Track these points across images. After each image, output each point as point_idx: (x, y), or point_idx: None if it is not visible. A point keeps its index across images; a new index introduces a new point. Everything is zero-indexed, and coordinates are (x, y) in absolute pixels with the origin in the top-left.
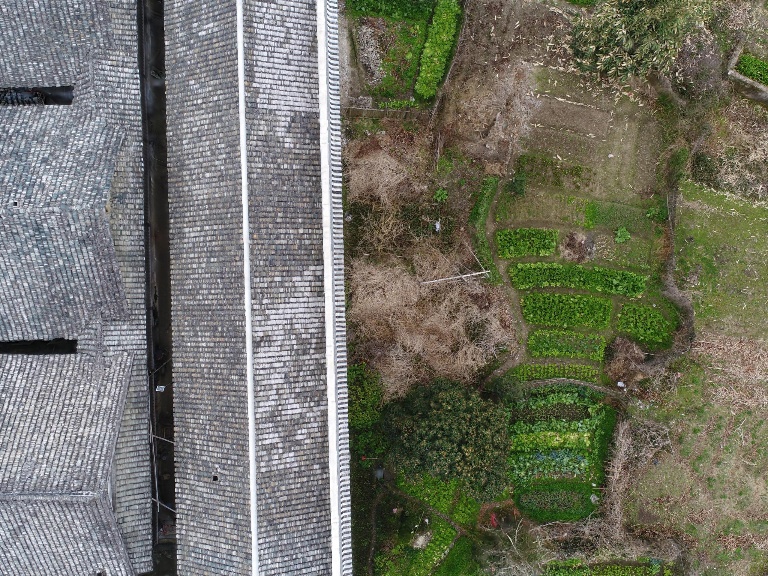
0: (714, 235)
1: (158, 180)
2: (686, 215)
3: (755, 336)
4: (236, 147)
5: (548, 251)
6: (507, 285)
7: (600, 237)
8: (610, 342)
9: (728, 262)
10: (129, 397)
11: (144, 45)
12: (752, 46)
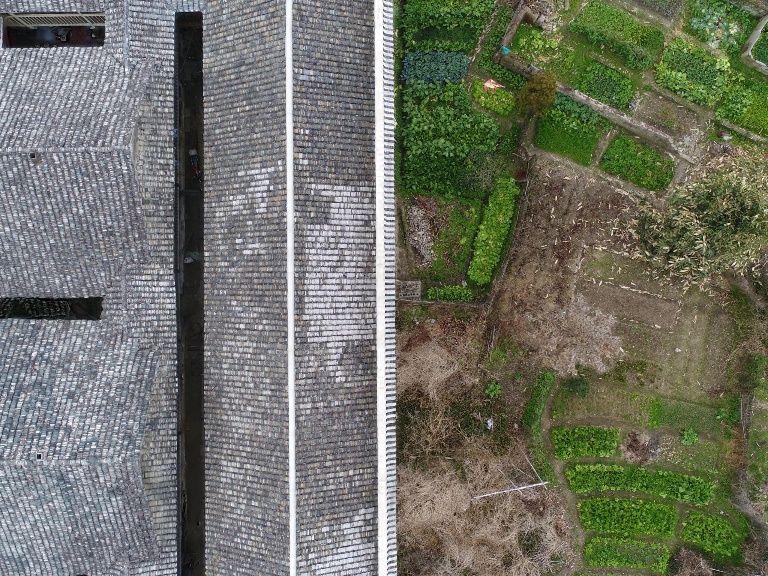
0: None
1: (188, 368)
2: (758, 417)
3: None
4: (283, 387)
5: (609, 453)
6: (563, 487)
7: (665, 438)
8: (674, 552)
9: None
10: None
11: (178, 236)
12: None
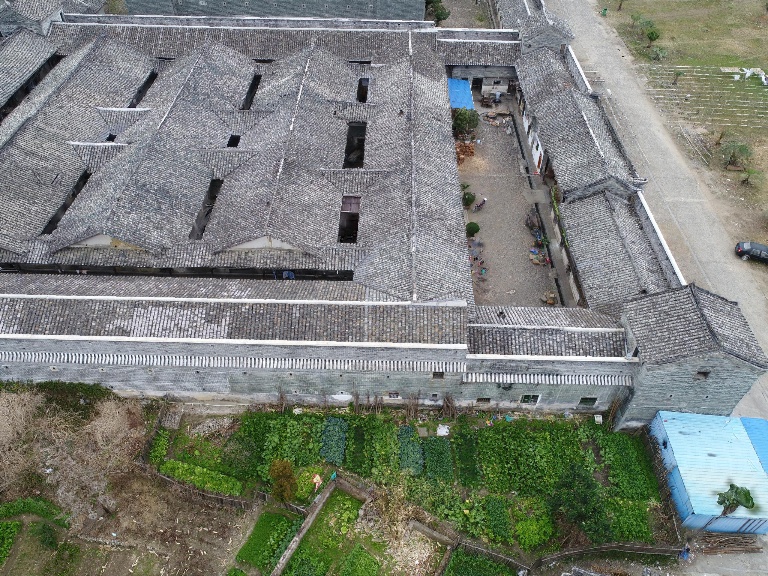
0: None
1: None
2: None
3: None
4: None
5: None
6: None
7: None
8: None
9: None
10: (1, 252)
11: None
12: None
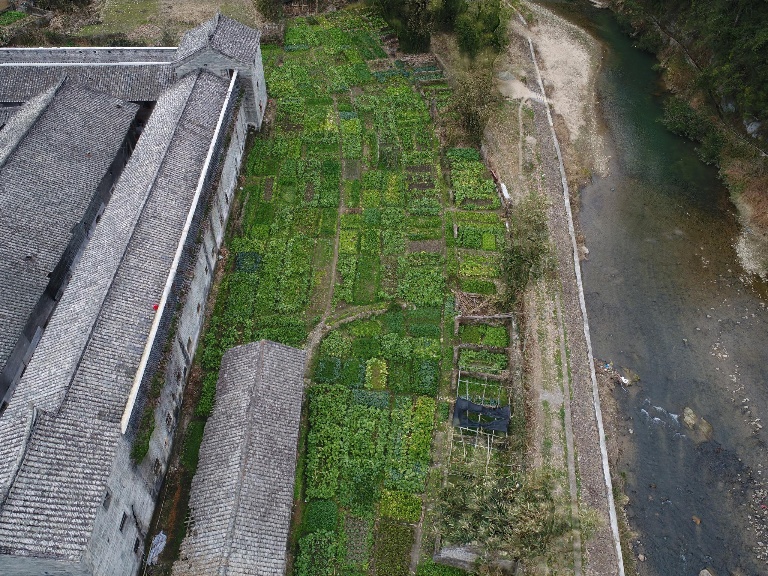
0: None
1: None
2: None
3: None
4: None
5: None
6: None
7: None
8: None
9: None
10: None
11: None
12: None
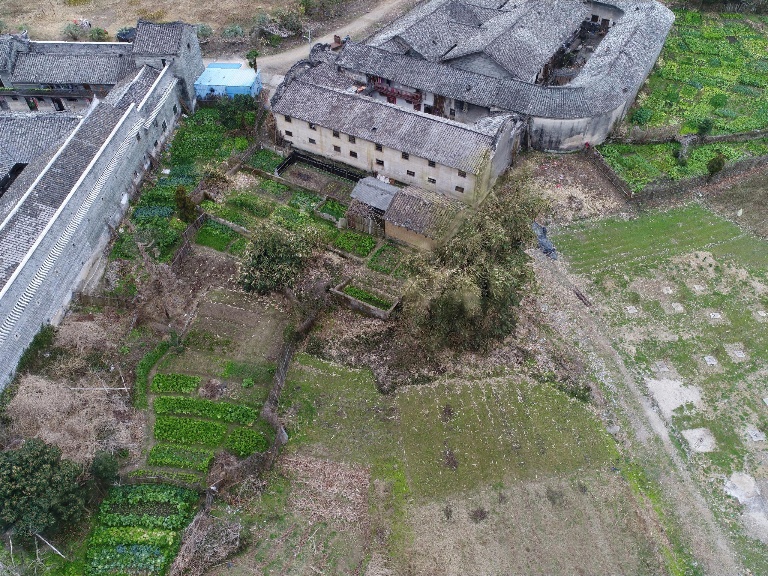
0: (316, 387)
1: None
2: (298, 373)
3: (338, 459)
4: None
5: (188, 389)
6: (150, 412)
7: (231, 383)
8: None
9: (324, 405)
10: None
11: None
12: (356, 284)
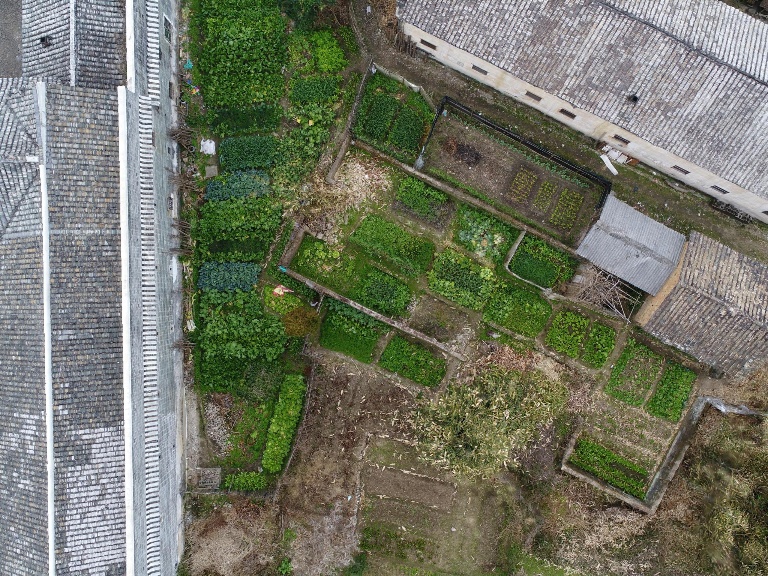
0: None
1: None
2: None
3: None
4: None
5: None
6: None
7: None
8: None
9: None
10: None
11: None
12: (590, 429)
